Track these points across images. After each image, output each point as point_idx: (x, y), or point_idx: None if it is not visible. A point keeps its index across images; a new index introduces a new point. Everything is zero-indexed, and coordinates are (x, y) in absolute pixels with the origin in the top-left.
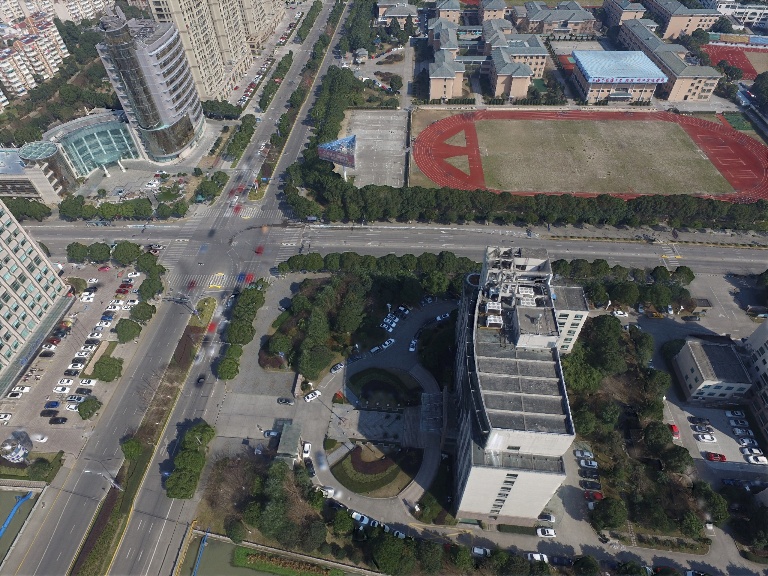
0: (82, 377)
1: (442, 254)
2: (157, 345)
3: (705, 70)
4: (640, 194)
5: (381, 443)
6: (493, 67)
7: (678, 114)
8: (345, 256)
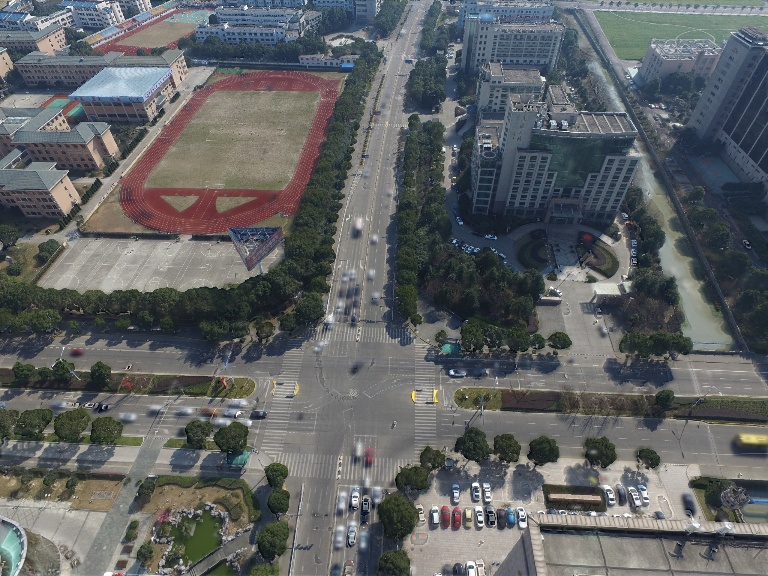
0: (605, 506)
1: (407, 203)
2: (535, 435)
3: (172, 53)
4: (313, 122)
5: (579, 254)
6: (48, 149)
7: (203, 88)
8: (411, 262)
